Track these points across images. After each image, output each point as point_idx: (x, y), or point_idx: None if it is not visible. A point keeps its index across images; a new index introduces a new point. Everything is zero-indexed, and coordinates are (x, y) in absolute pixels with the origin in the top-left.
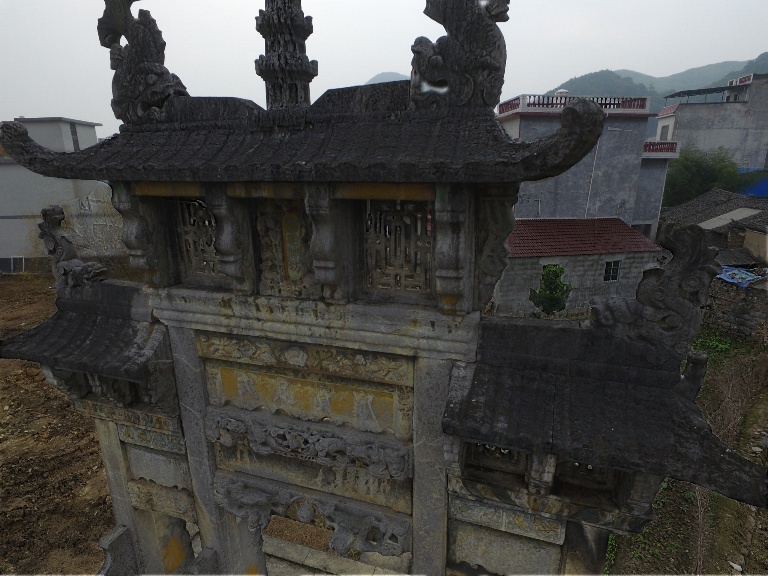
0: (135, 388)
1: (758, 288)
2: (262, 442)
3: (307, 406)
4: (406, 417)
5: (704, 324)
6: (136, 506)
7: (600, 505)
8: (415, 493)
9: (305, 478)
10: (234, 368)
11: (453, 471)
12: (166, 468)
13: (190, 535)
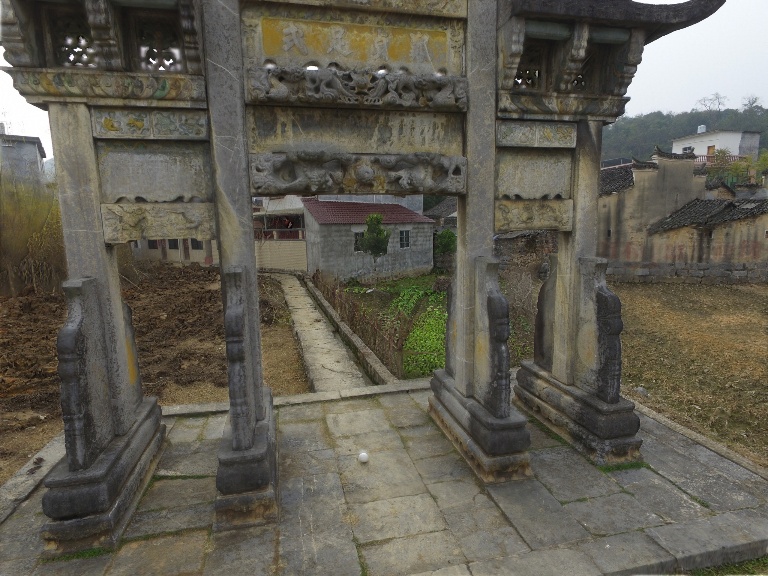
0: (128, 55)
1: (502, 238)
2: (328, 82)
3: (363, 55)
4: (458, 54)
5: None
6: (112, 239)
7: (600, 96)
8: (470, 124)
9: (359, 142)
10: (279, 17)
11: (508, 81)
12: (167, 172)
13: None
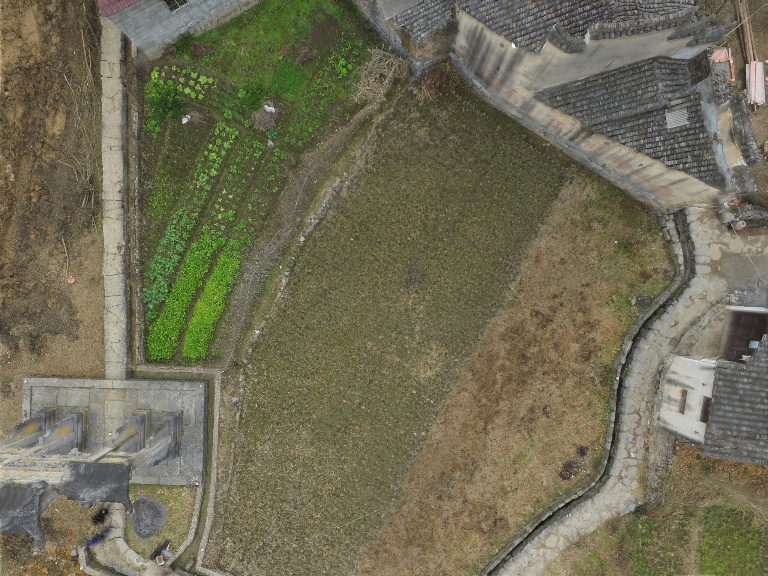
0: None
1: None
2: None
3: None
4: None
5: (354, 3)
6: None
7: None
8: None
9: None
10: None
11: None
12: None
13: (29, 389)
